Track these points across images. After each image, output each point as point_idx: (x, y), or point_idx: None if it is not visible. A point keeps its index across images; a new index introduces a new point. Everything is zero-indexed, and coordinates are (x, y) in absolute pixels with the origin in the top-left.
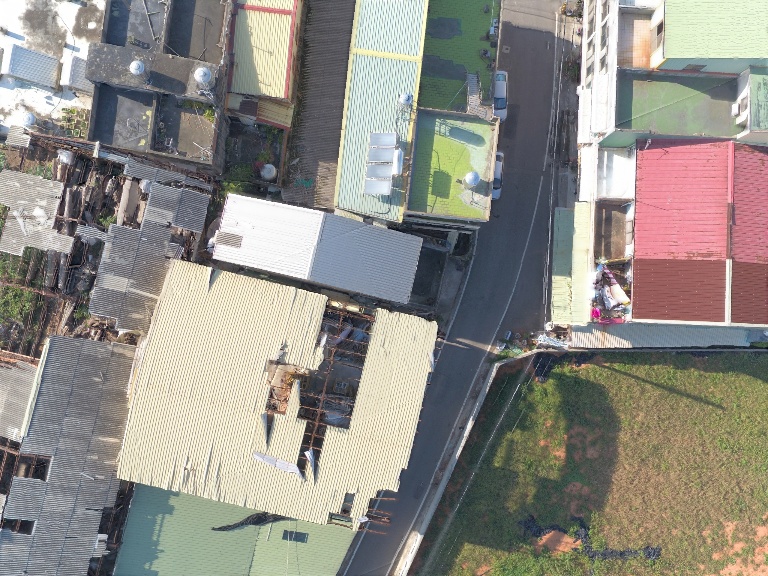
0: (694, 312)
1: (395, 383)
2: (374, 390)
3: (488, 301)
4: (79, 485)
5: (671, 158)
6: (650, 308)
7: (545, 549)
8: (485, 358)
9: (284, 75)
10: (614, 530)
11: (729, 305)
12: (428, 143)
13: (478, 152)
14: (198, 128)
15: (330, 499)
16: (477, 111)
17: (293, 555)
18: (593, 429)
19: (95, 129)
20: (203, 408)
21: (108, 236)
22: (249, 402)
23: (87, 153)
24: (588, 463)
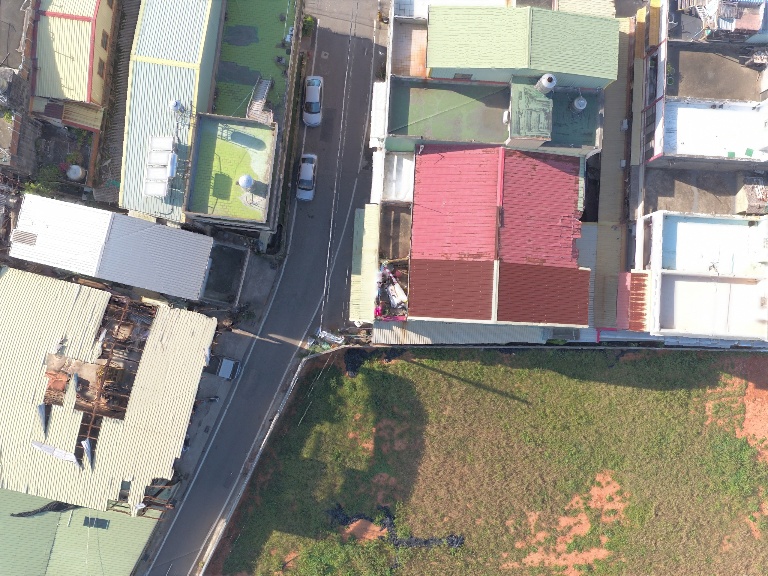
0: (464, 310)
1: (170, 376)
2: (149, 383)
3: (301, 298)
4: None
5: (446, 163)
6: (424, 306)
7: (351, 537)
8: (296, 353)
9: (86, 79)
10: (419, 519)
11: (496, 304)
12: (210, 147)
13: (259, 156)
14: None
15: (107, 487)
16: (259, 116)
17: (94, 541)
18: (401, 422)
19: None
20: None
21: None
22: (28, 394)
23: None
24: (395, 455)
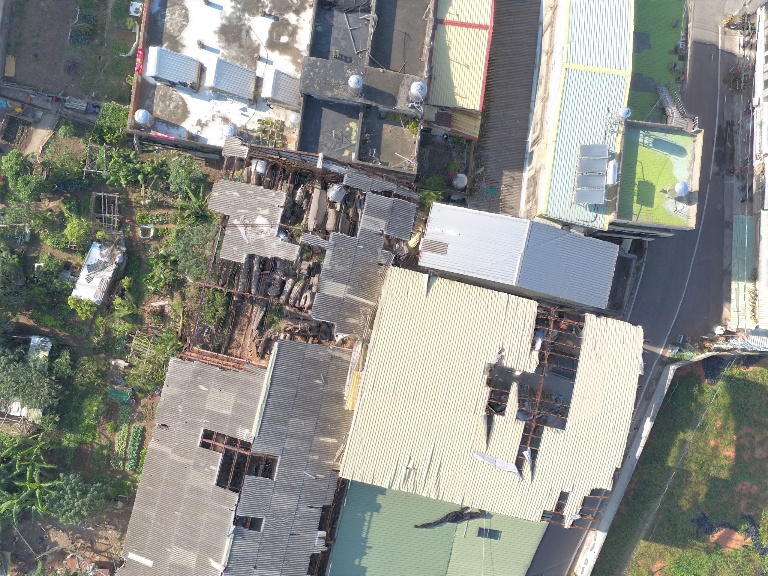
0: None
1: (608, 385)
2: (588, 392)
3: (659, 306)
4: (302, 484)
5: None
6: None
7: (717, 546)
8: (657, 361)
9: (480, 88)
10: None
11: None
12: (632, 154)
13: (680, 163)
14: (399, 139)
15: (545, 497)
16: (678, 123)
17: (487, 552)
18: (761, 430)
19: (301, 140)
20: (426, 409)
21: (329, 244)
22: (470, 404)
23: (287, 163)
24: (757, 463)
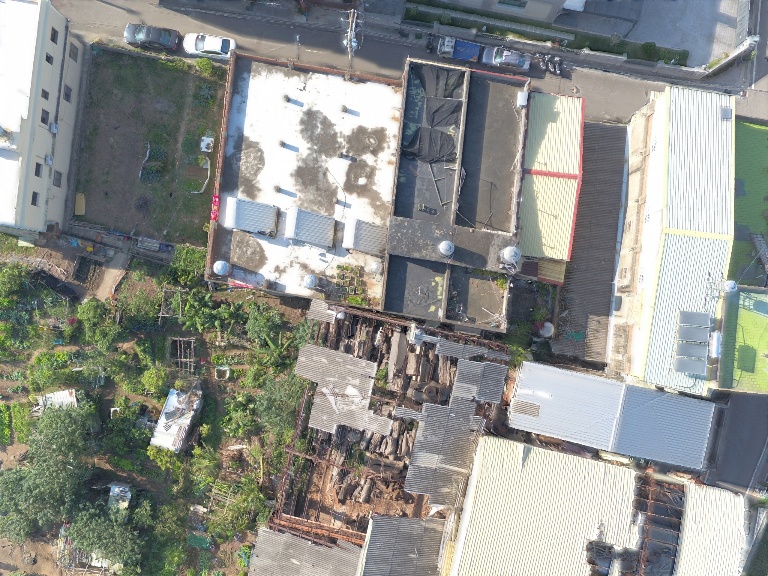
0: None
1: (710, 560)
2: (690, 568)
3: (745, 443)
4: None
5: None
6: None
7: None
8: (744, 500)
9: (568, 237)
10: None
11: None
12: (732, 317)
13: None
14: (486, 293)
15: None
16: None
17: None
18: None
19: (386, 296)
20: None
21: (422, 415)
22: None
23: None
24: None
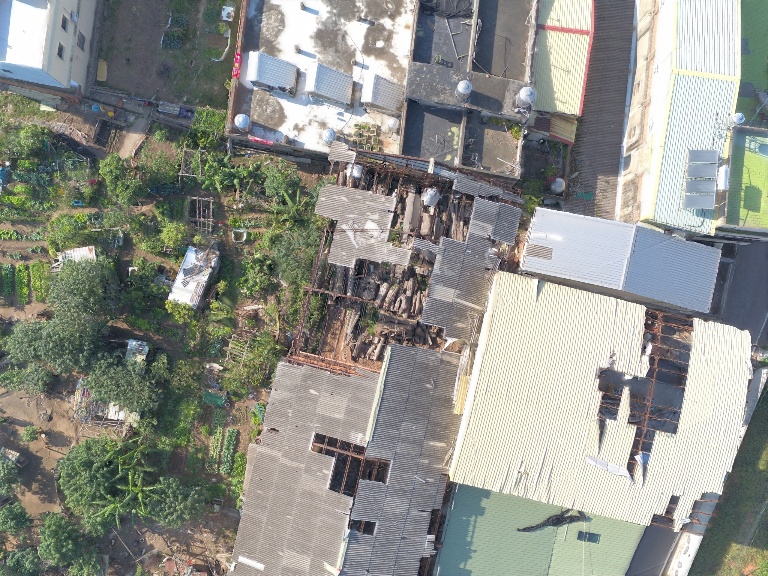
0: None
1: (718, 390)
2: (699, 396)
3: (749, 310)
4: (413, 488)
5: None
6: None
7: None
8: None
9: (580, 93)
10: None
11: None
12: (739, 159)
13: None
14: (501, 144)
15: (656, 501)
16: None
17: (587, 555)
18: None
19: (403, 145)
20: (538, 414)
21: (439, 249)
22: (582, 408)
23: (386, 168)
24: None
